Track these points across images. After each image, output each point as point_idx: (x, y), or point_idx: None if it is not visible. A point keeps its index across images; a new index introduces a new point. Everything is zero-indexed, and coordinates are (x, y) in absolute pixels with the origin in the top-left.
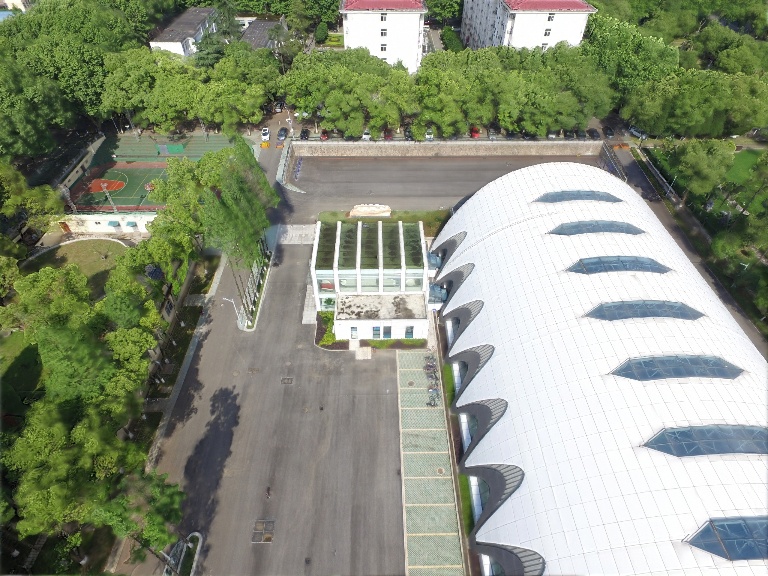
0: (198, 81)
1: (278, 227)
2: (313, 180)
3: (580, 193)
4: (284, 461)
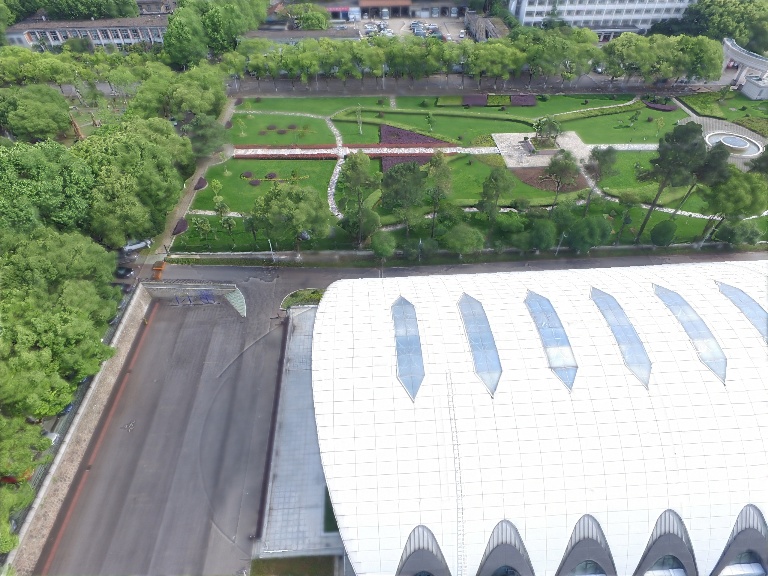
0: None
1: None
2: None
3: (400, 336)
4: None
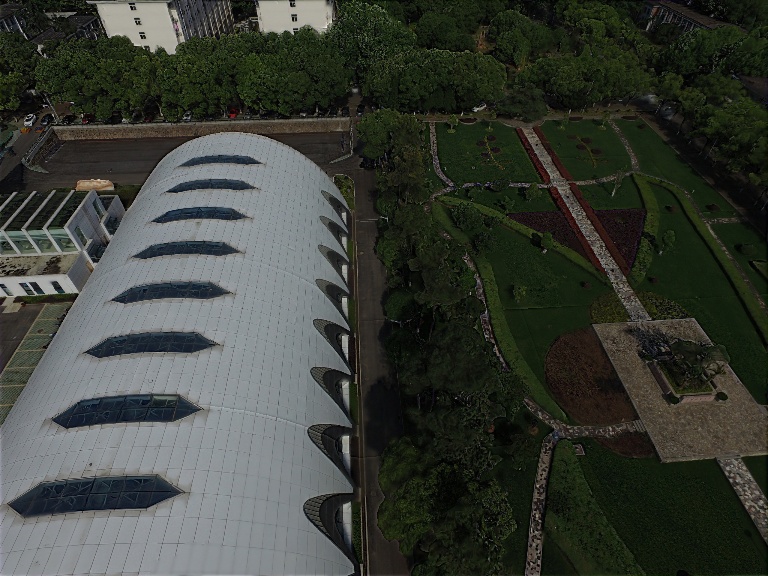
0: None
1: None
2: (62, 161)
3: (220, 157)
4: None
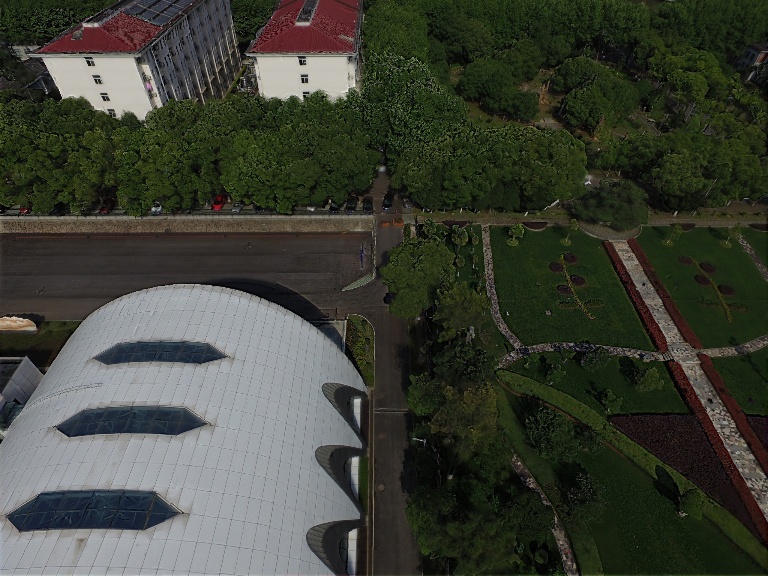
0: None
1: None
2: None
3: (160, 346)
4: None
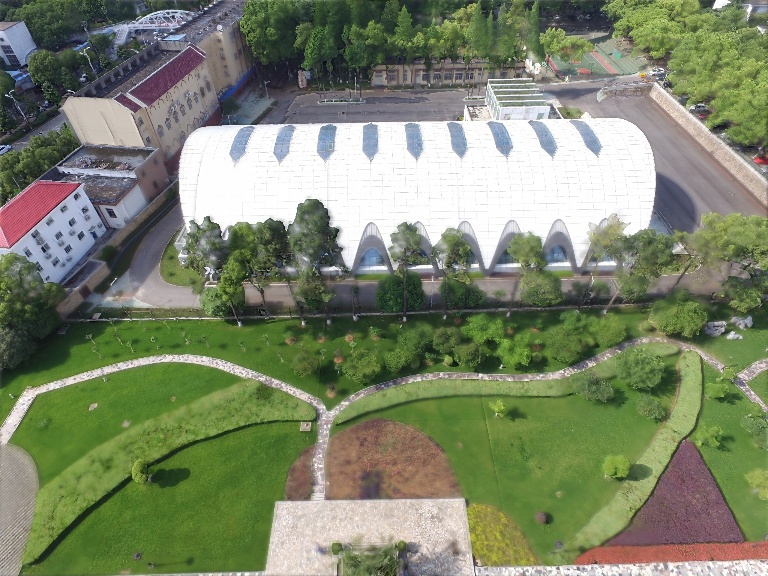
0: (667, 18)
1: (552, 96)
2: (619, 103)
3: (589, 131)
4: (394, 114)
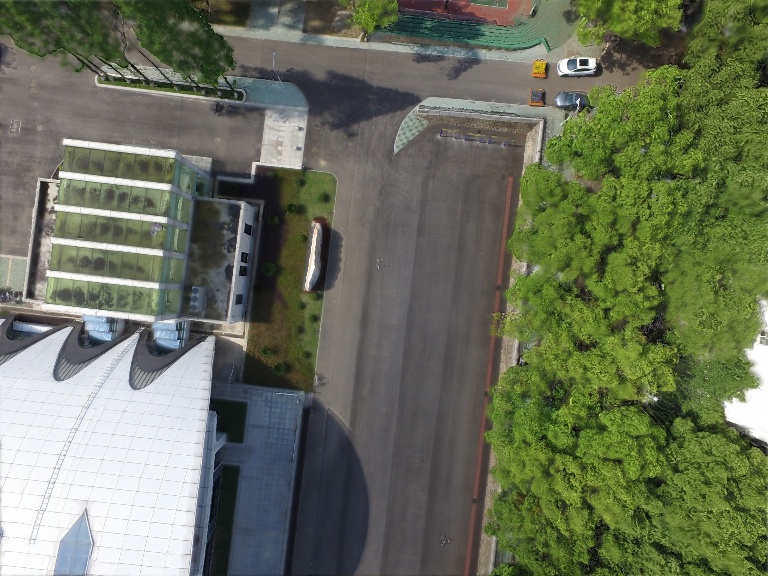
0: None
1: (299, 107)
2: (435, 166)
3: None
4: None
